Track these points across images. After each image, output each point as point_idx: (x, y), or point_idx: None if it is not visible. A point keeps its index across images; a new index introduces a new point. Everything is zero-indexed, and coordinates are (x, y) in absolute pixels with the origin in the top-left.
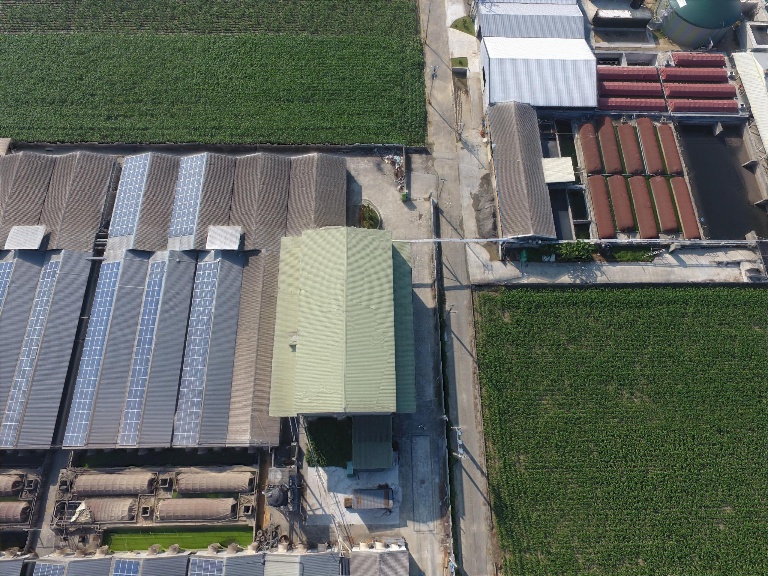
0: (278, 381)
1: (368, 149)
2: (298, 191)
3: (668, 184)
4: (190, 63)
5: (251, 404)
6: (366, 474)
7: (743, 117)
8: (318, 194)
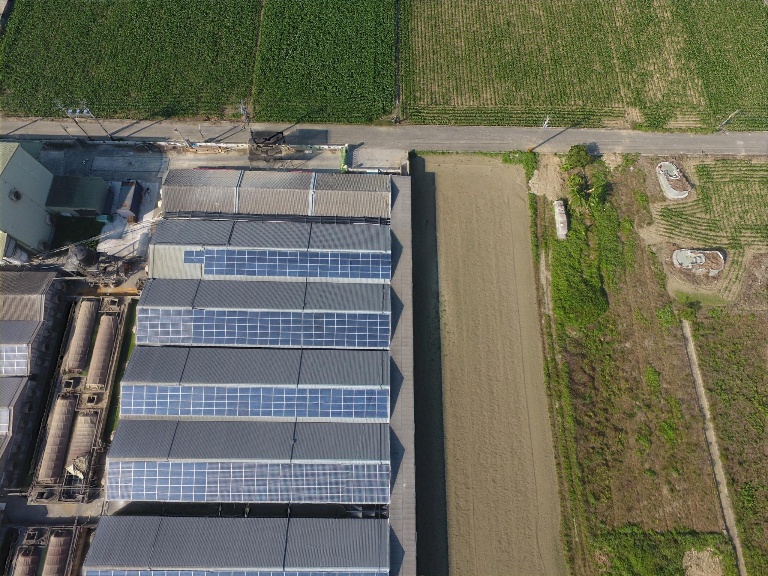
0: None
1: None
2: None
3: None
4: None
5: (3, 296)
6: (114, 207)
7: None
8: None
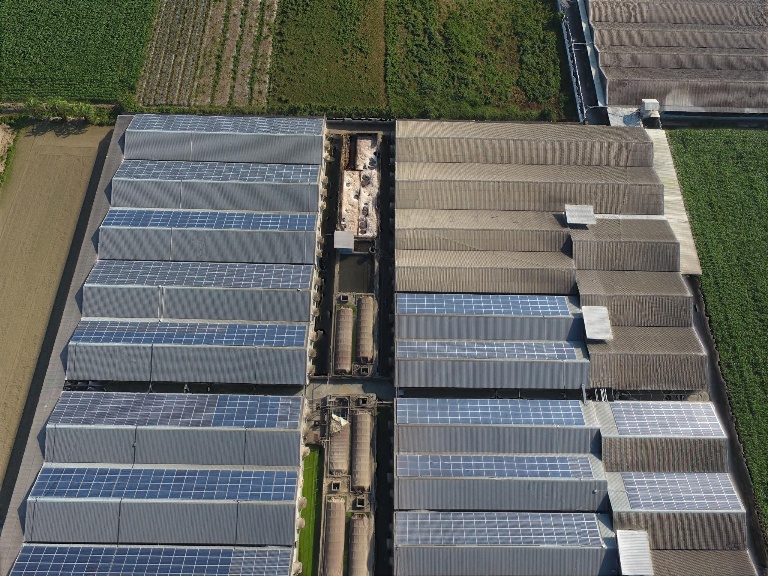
0: None
1: None
2: None
3: None
4: None
5: None
6: None
7: None
8: None
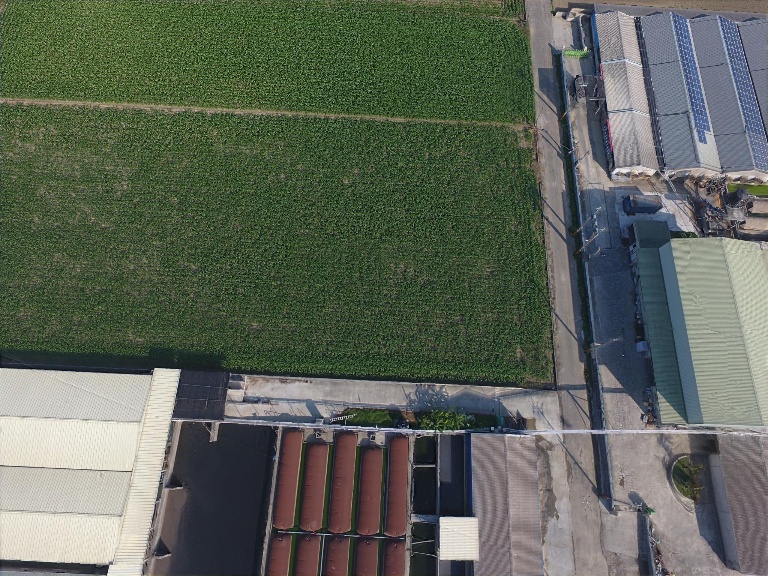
0: None
1: None
2: None
3: (298, 519)
4: None
5: None
6: None
7: None
8: None
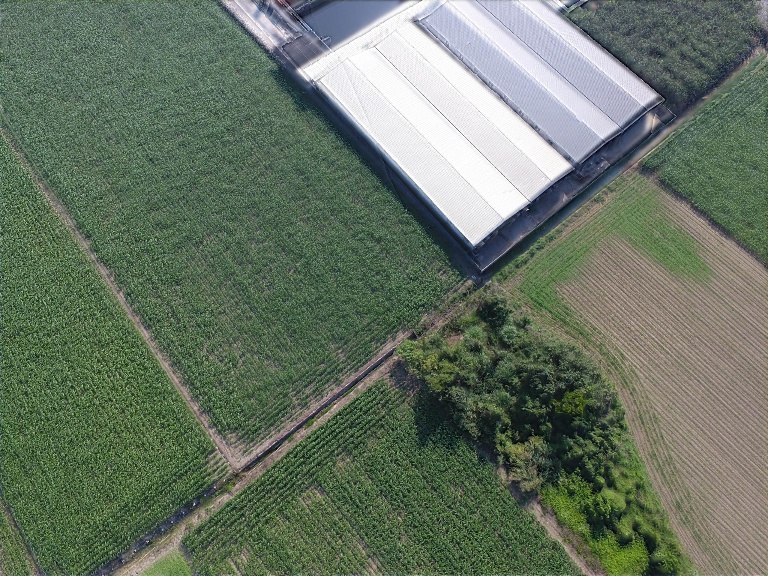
0: None
1: None
2: None
3: None
4: None
5: None
6: None
7: None
8: None
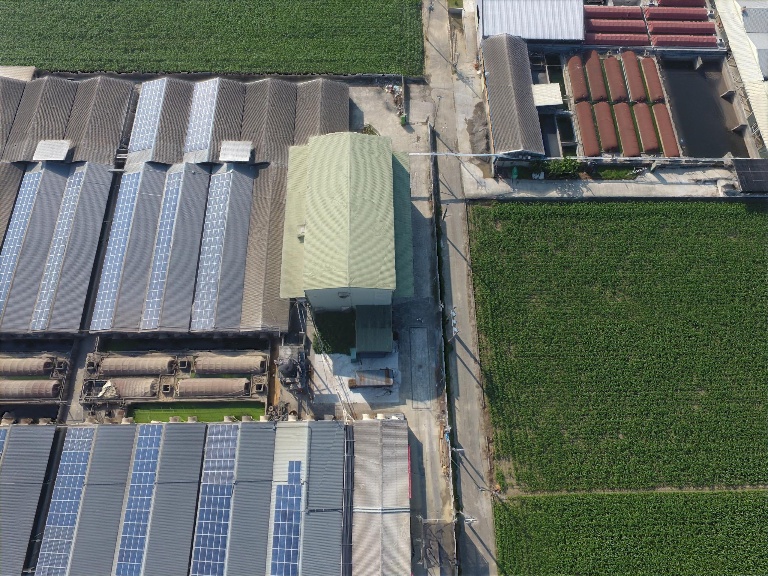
0: (288, 268)
1: (369, 79)
2: (304, 112)
3: (650, 110)
4: (201, 3)
5: (262, 294)
6: (368, 360)
7: (722, 51)
8: (323, 114)
